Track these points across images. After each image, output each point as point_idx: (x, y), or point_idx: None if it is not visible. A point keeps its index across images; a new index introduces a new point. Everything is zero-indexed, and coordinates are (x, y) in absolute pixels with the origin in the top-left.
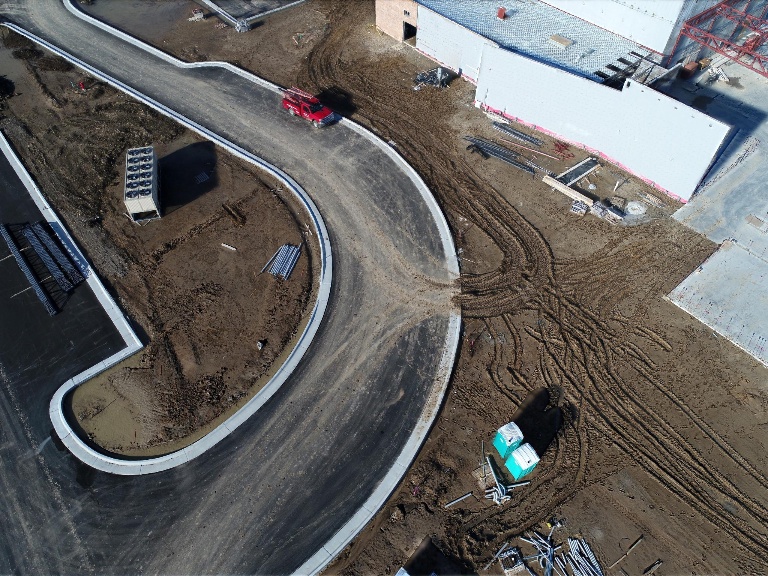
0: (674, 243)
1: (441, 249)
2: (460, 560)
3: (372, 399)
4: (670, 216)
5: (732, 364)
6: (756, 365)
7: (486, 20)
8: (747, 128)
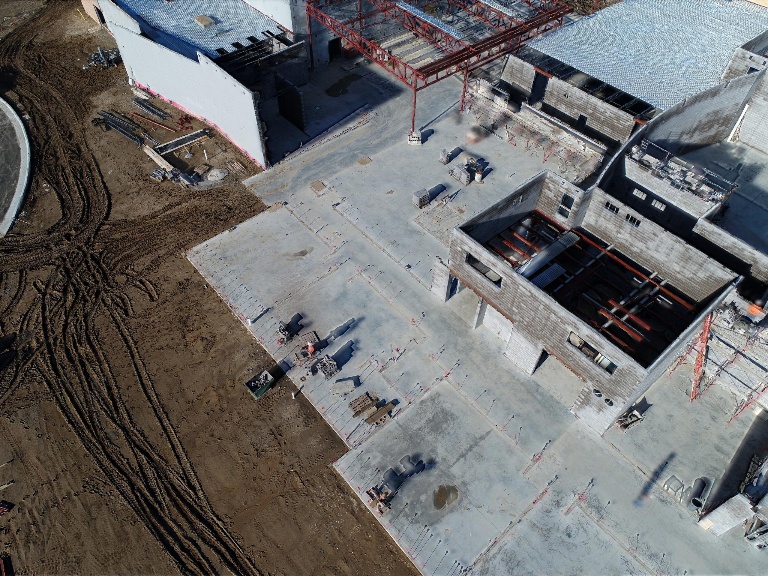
0: (228, 206)
1: (4, 212)
2: None
3: None
4: (241, 182)
5: (204, 312)
6: (225, 312)
7: (152, 2)
8: (374, 103)
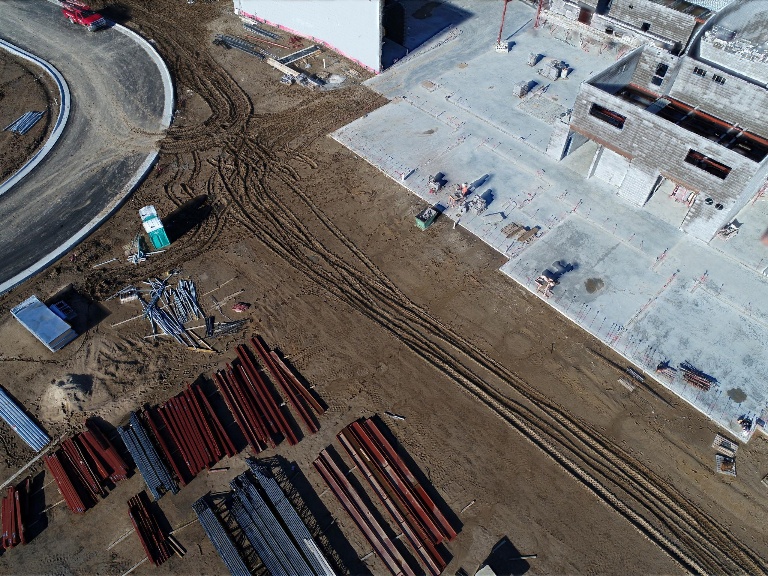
0: (355, 101)
1: (161, 111)
2: (90, 296)
3: (63, 207)
4: (360, 83)
5: (360, 174)
6: (378, 174)
7: None
8: (458, 23)
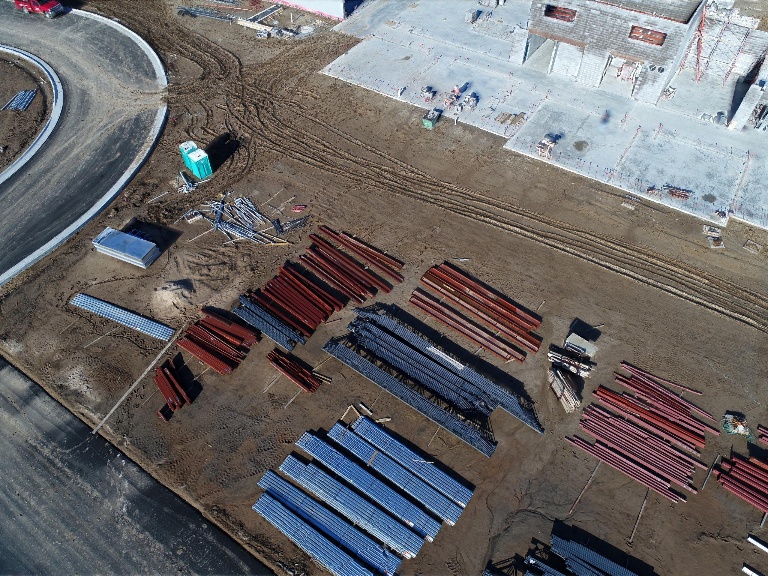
0: (331, 43)
1: (153, 74)
2: (157, 223)
3: (95, 161)
4: (330, 29)
5: (360, 97)
6: (375, 95)
7: None
8: None
